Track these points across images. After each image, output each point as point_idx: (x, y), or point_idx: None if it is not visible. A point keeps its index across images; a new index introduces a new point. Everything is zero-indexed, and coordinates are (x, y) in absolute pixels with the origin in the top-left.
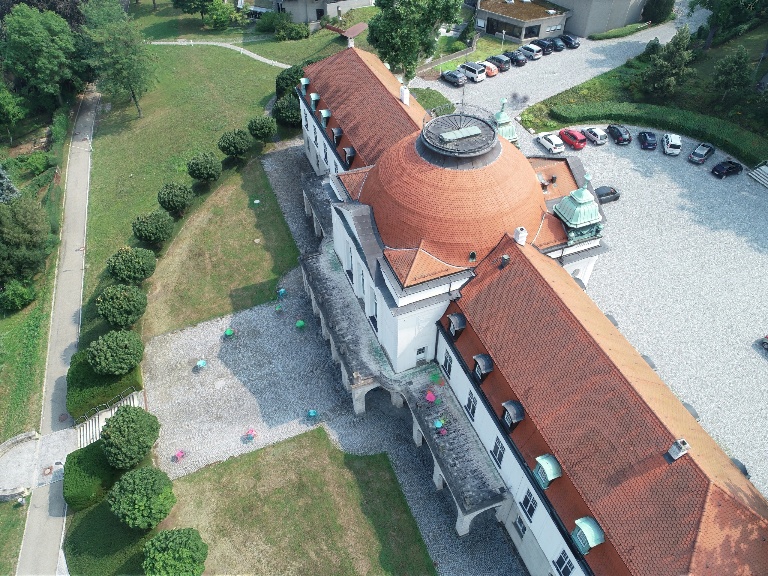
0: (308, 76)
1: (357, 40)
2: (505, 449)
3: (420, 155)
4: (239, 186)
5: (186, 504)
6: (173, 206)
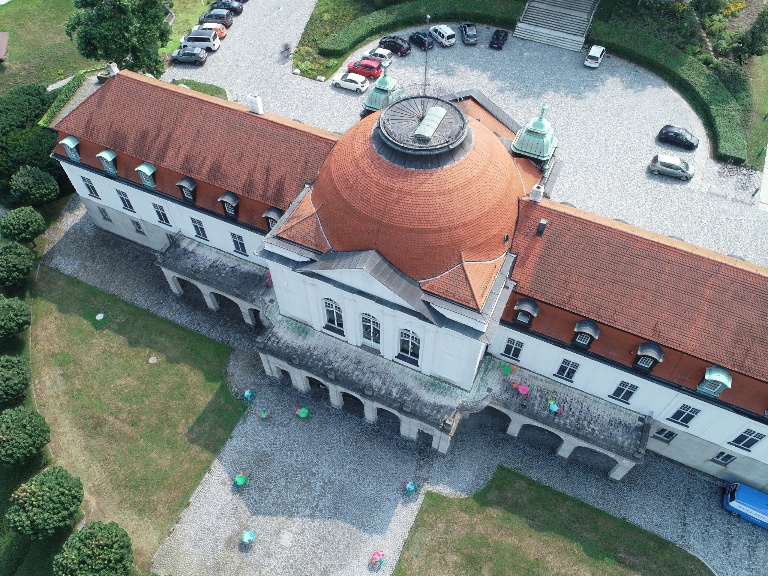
0: (73, 134)
1: (12, 58)
2: (639, 387)
3: (404, 167)
4: (56, 312)
5: None
6: (14, 393)
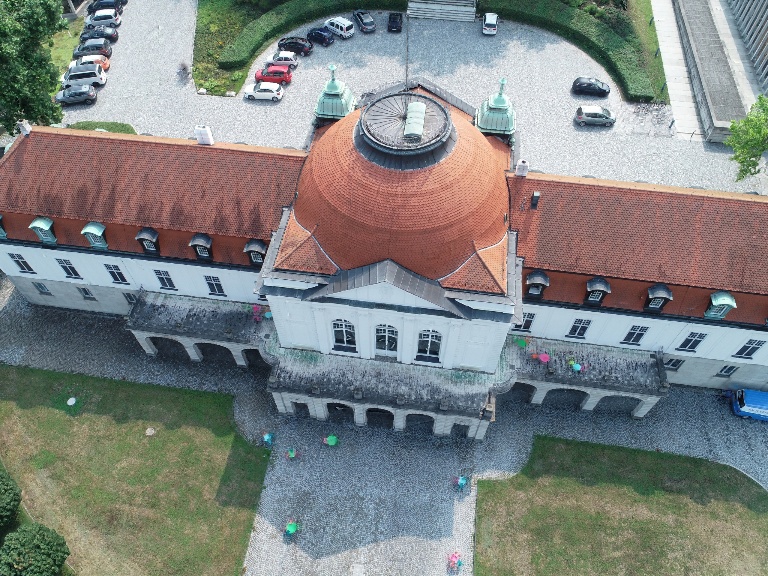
0: None
1: None
2: (649, 327)
3: (401, 169)
4: (18, 411)
5: None
6: (9, 514)
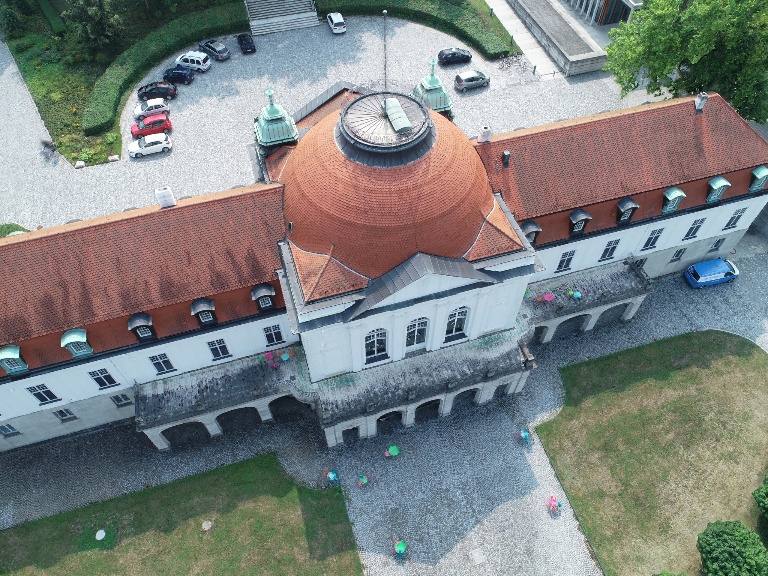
0: None
1: None
2: None
3: (404, 164)
4: (41, 573)
5: (642, 575)
6: None
